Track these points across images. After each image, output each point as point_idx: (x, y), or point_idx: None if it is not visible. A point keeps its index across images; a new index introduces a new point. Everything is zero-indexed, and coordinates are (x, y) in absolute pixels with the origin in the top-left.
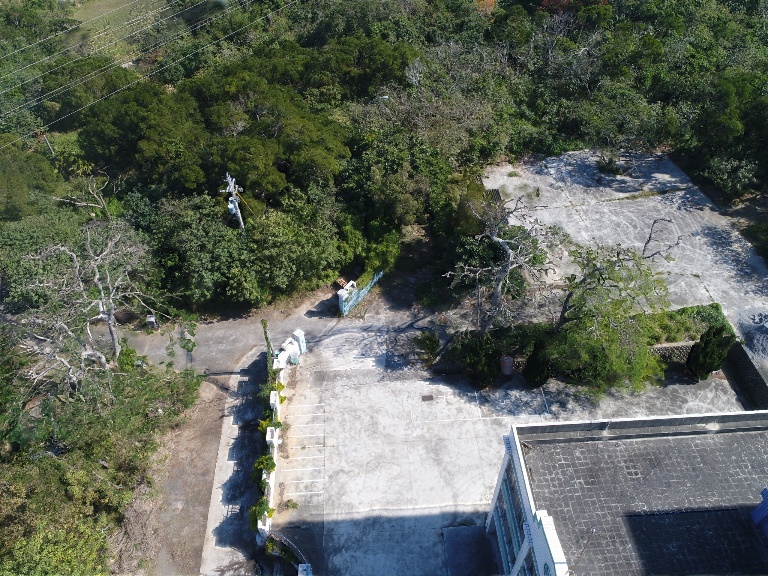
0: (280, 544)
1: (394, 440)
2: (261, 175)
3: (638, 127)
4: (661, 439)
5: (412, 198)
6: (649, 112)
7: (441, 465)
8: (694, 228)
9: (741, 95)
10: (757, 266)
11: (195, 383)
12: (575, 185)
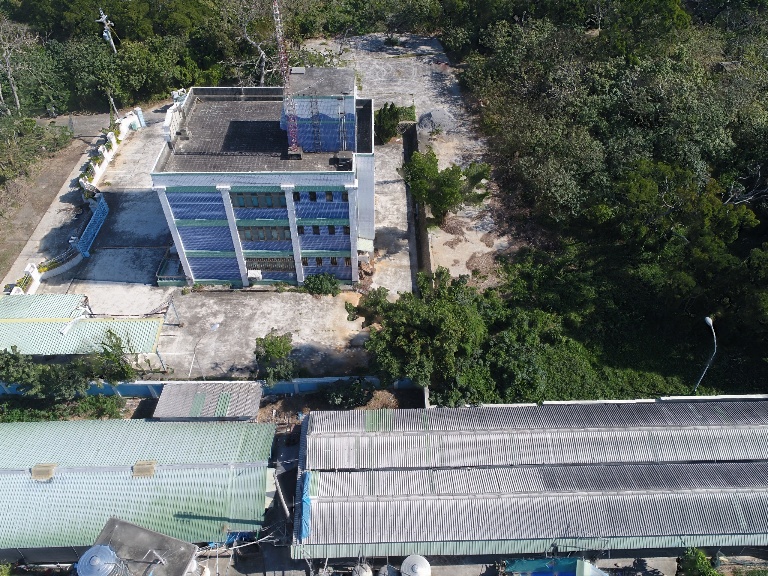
0: (92, 193)
1: None
2: (135, 25)
3: (404, 9)
4: (273, 102)
5: (227, 36)
6: (421, 3)
7: None
8: (427, 73)
9: None
10: (453, 90)
11: (68, 135)
12: (363, 50)
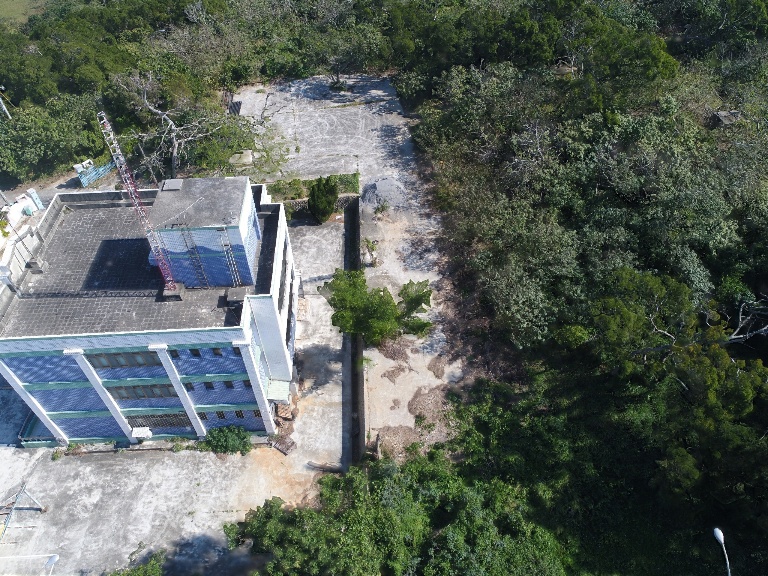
0: None
1: None
2: (36, 83)
3: (349, 50)
4: None
5: None
6: (369, 41)
7: None
8: (376, 126)
9: (407, 19)
10: (405, 149)
11: None
12: (304, 98)
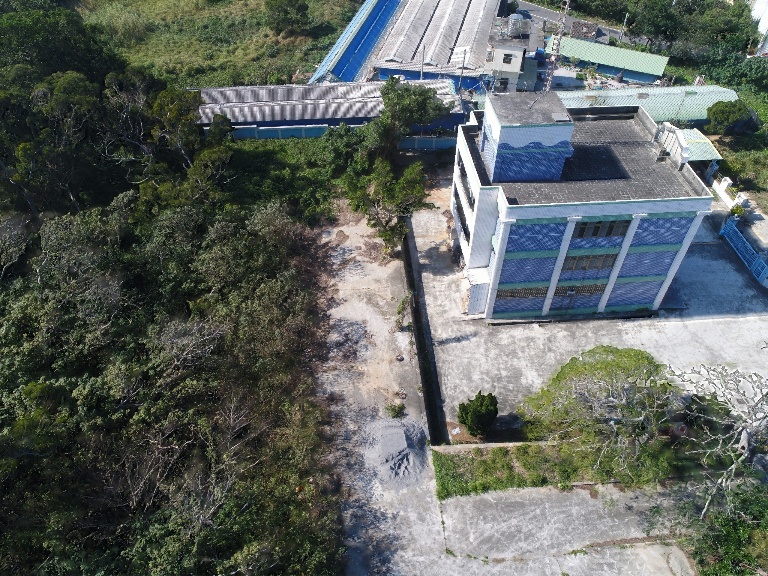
0: None
1: (755, 364)
2: None
3: None
4: None
5: None
6: None
7: (705, 346)
8: None
9: None
10: (360, 567)
11: None
12: None
